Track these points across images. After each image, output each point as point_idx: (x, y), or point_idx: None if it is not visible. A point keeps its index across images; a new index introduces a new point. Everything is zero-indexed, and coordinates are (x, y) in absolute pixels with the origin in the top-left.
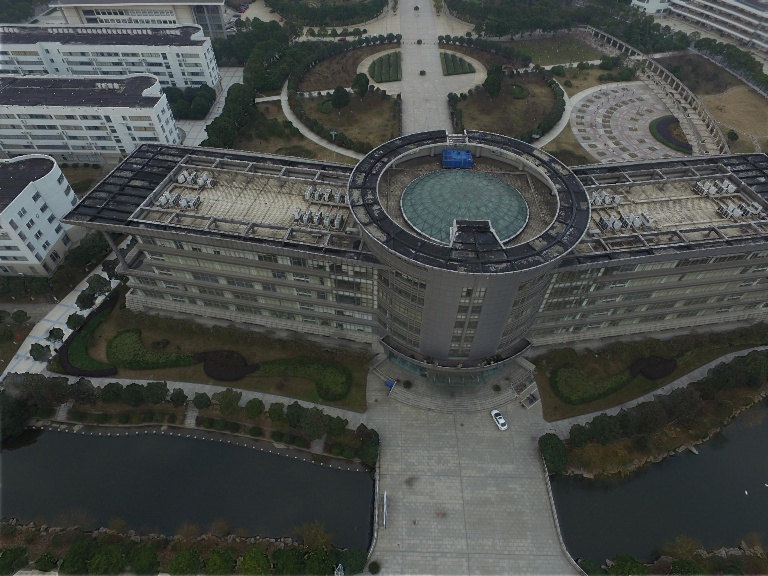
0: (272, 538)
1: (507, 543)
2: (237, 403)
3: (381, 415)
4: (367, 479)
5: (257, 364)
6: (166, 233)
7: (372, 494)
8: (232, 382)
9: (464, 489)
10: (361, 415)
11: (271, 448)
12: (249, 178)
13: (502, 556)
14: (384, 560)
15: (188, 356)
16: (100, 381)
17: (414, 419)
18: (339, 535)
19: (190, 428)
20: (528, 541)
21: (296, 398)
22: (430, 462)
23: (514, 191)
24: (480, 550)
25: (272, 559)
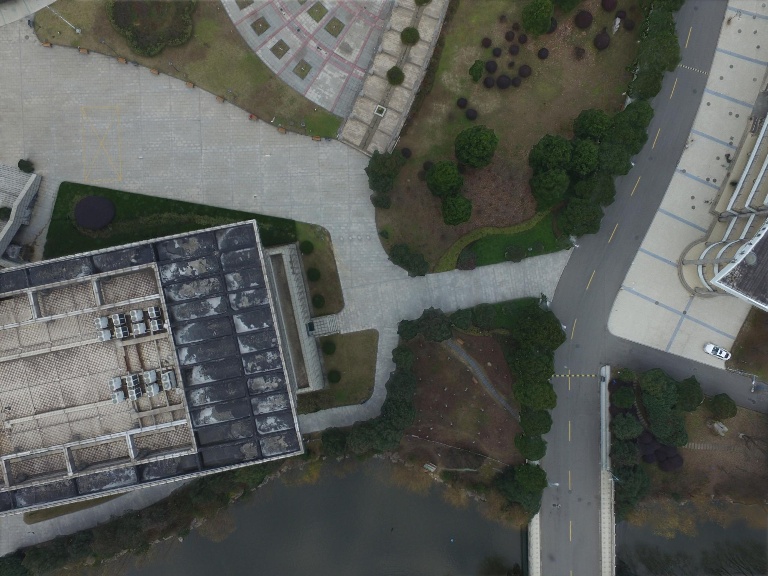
0: None
1: None
2: None
3: None
4: None
5: None
6: None
7: None
8: None
9: None
10: None
11: None
12: None
13: None
14: None
15: None
16: None
17: None
18: None
19: None
20: None
21: None
22: None
23: None
24: None
25: None
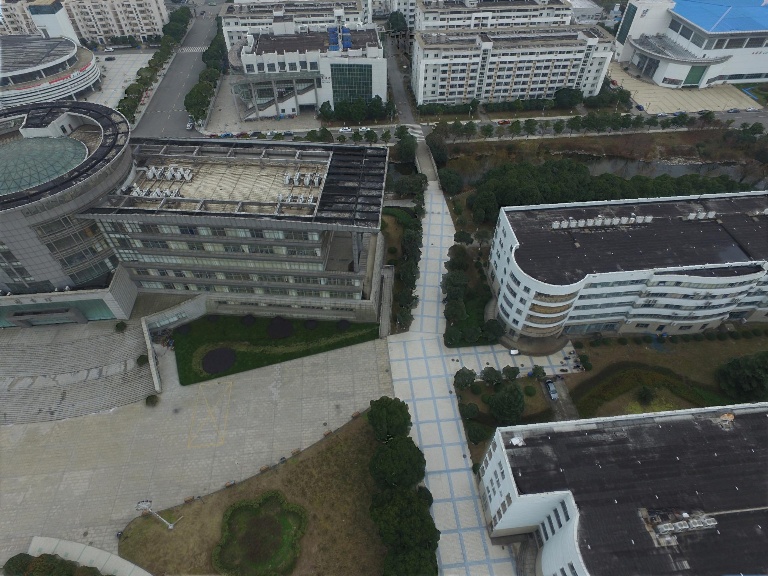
0: None
1: None
2: None
3: None
4: None
5: None
6: (293, 142)
7: None
8: None
9: None
10: None
11: None
12: None
13: None
14: None
15: None
16: None
17: None
18: None
19: None
20: None
21: None
22: None
23: None
24: None
25: None
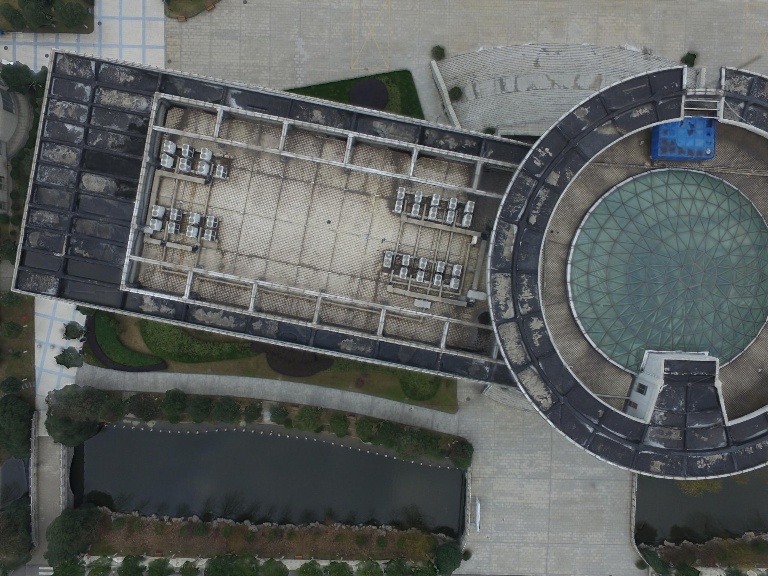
0: (374, 526)
1: (584, 536)
2: (319, 419)
3: (473, 416)
4: (457, 472)
5: (329, 358)
6: (194, 327)
7: (464, 493)
8: (304, 377)
9: (552, 491)
10: (452, 416)
11: (359, 445)
12: (285, 146)
13: (577, 545)
14: (475, 549)
15: (244, 347)
16: (153, 376)
17: (509, 421)
18: (429, 505)
19: (270, 424)
20: (603, 534)
21: (379, 396)
22: (522, 466)
23: (767, 246)
24: (559, 541)
25: (377, 546)
